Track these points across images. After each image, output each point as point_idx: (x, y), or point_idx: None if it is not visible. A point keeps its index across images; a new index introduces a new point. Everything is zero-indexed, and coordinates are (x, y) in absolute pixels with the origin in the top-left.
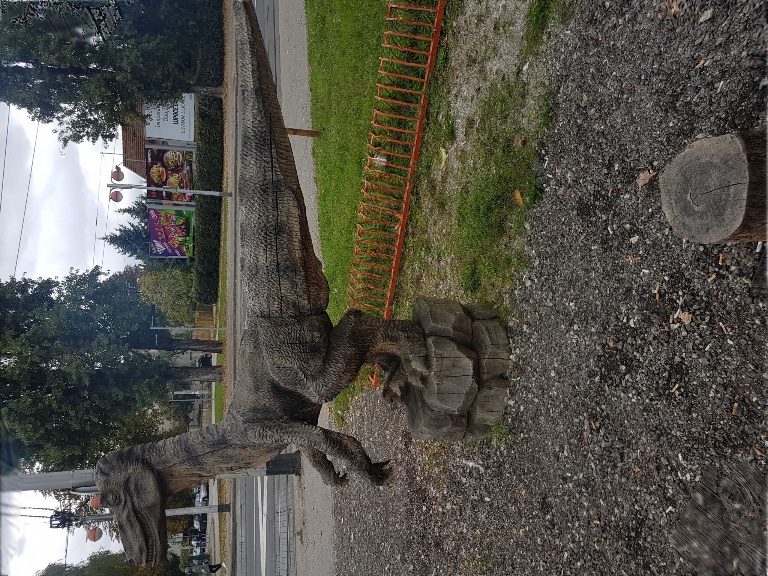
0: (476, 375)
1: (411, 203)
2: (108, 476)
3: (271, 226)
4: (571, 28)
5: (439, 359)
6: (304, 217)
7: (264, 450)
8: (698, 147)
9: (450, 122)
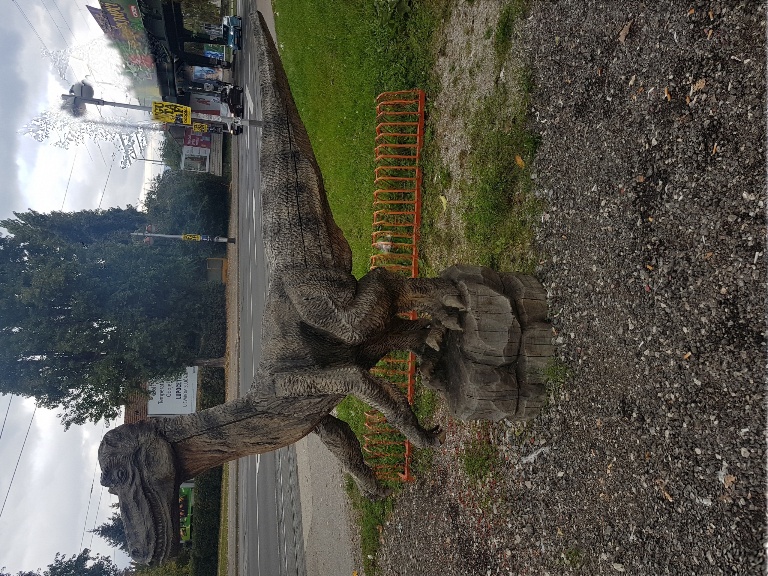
0: (516, 315)
1: (420, 267)
2: (115, 449)
3: (291, 187)
4: (533, 13)
5: (474, 296)
6: (322, 186)
7: (294, 423)
8: None
9: (445, 171)
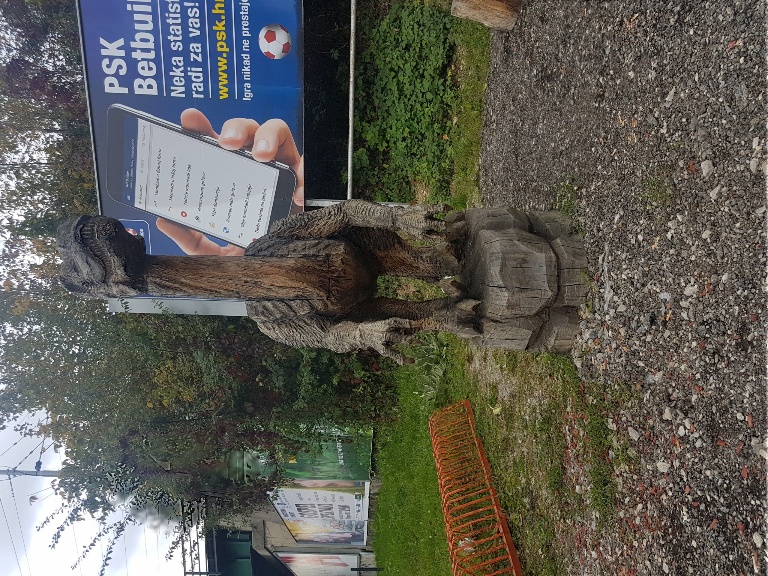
0: None
1: None
2: None
3: None
4: None
5: None
6: None
7: None
8: None
9: None
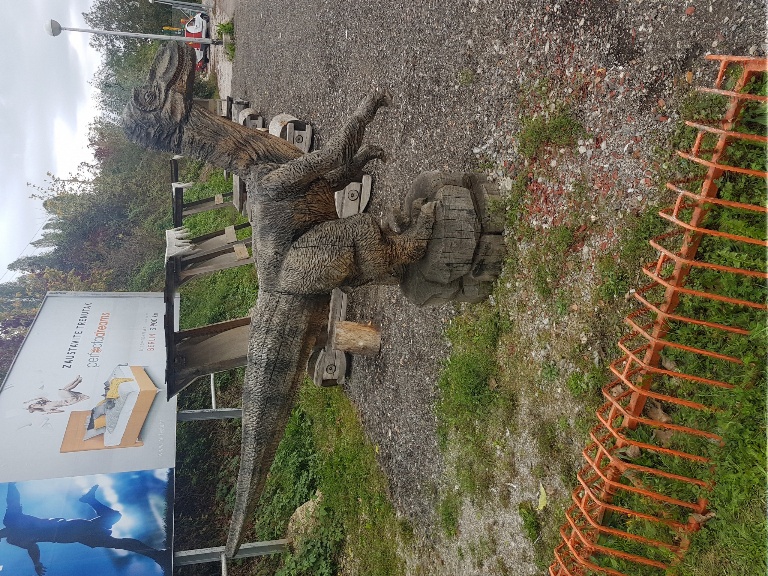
0: None
1: None
2: None
3: None
4: None
5: None
6: None
7: None
8: (332, 347)
9: None
